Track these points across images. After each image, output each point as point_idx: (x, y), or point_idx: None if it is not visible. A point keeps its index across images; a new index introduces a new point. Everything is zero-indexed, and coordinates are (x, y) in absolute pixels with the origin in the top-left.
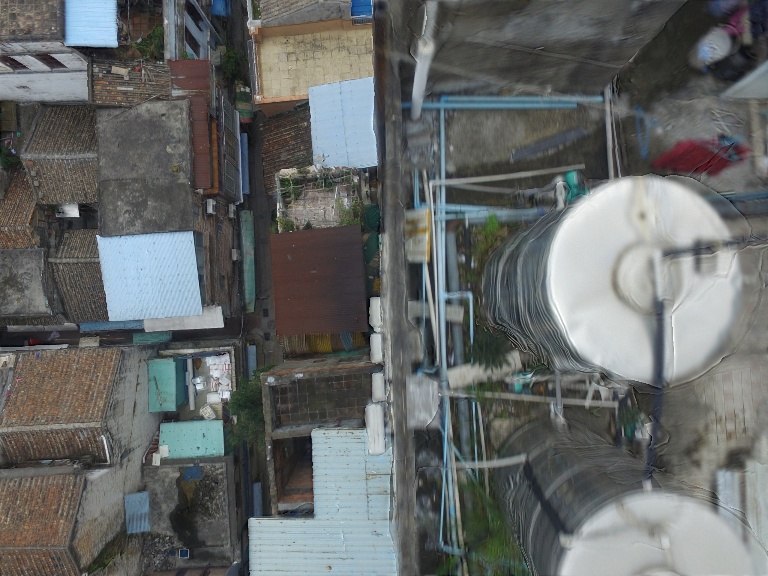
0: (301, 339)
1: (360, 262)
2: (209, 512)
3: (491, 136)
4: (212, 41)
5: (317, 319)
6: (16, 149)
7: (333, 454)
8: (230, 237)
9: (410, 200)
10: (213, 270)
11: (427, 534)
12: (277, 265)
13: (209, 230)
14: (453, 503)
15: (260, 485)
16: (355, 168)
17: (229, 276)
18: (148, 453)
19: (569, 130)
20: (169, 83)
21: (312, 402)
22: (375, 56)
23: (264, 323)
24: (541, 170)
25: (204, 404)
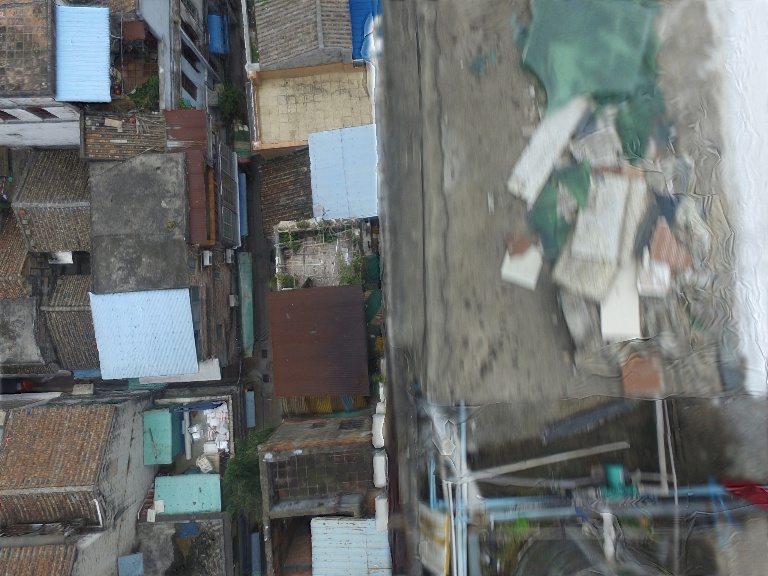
0: (300, 400)
1: (361, 324)
2: (205, 570)
3: (520, 411)
4: (210, 80)
5: (317, 381)
6: (8, 194)
7: (333, 546)
8: (228, 282)
9: (425, 497)
10: (210, 322)
11: None
12: (275, 324)
13: (206, 281)
14: None
15: (258, 535)
16: (356, 220)
17: (227, 323)
18: (143, 508)
19: (612, 404)
20: (164, 134)
21: (311, 476)
22: (386, 380)
23: (263, 364)
24: (579, 451)
25: (201, 453)
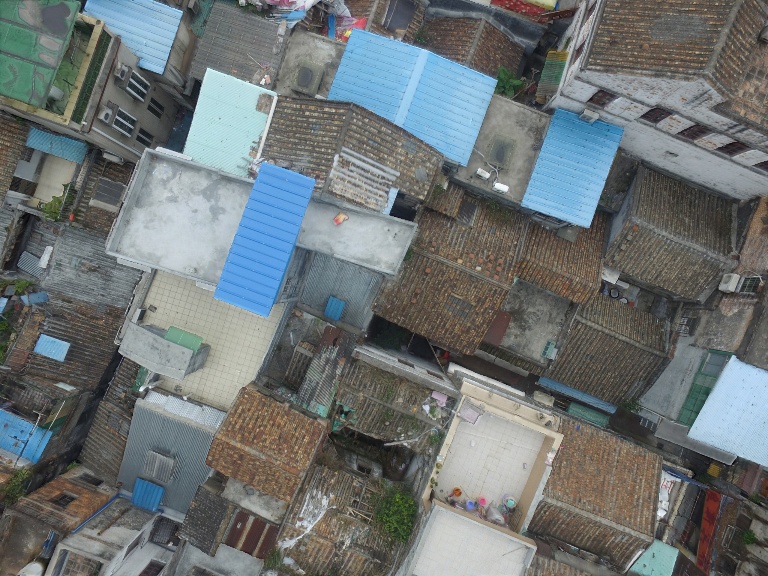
0: None
1: None
2: None
3: None
4: None
5: None
6: None
7: None
8: None
9: None
10: None
11: None
12: None
13: None
14: None
15: None
16: None
17: None
18: None
19: None
20: None
21: None
22: None
23: None
24: None
25: None
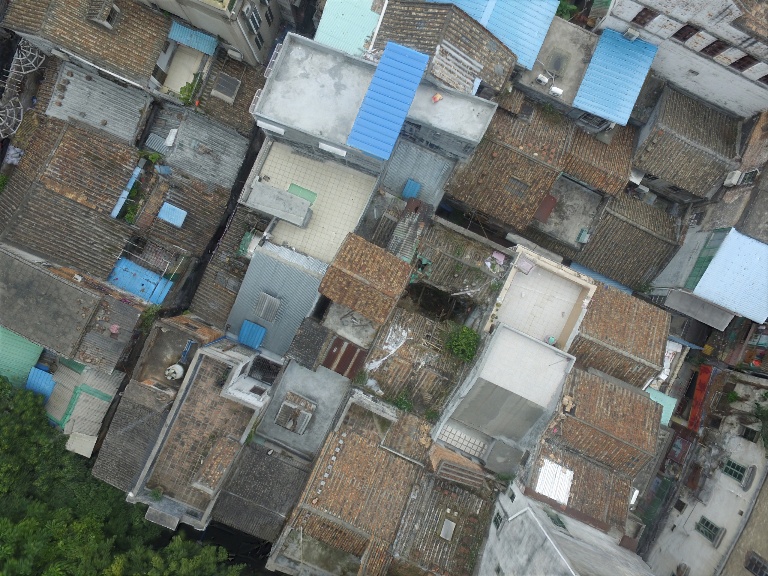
0: None
1: None
2: None
3: None
4: None
5: None
6: None
7: None
8: None
9: None
10: None
11: None
12: None
13: None
14: None
15: None
16: None
17: None
18: None
19: None
20: None
21: None
22: None
23: None
24: None
25: None
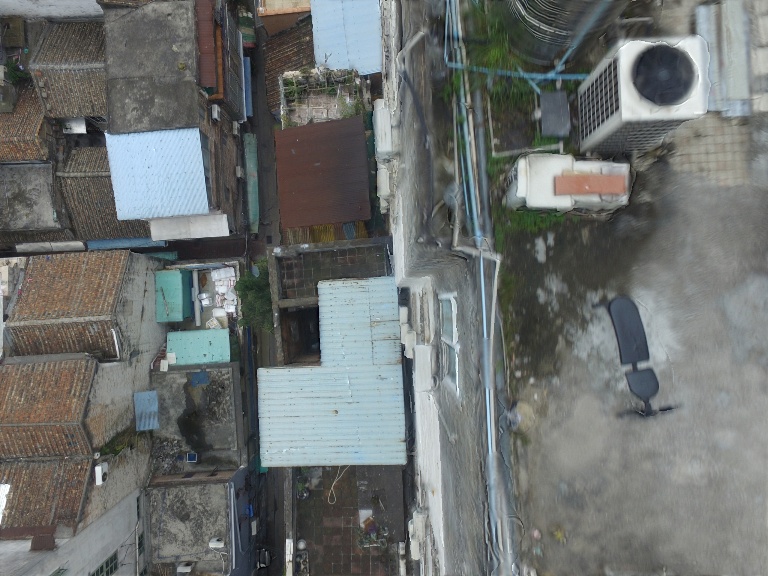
0: (305, 234)
1: (362, 152)
2: (216, 416)
3: None
4: None
5: (321, 210)
6: (24, 65)
7: (339, 304)
8: (234, 155)
9: None
10: (218, 177)
11: (433, 61)
12: (281, 160)
13: (214, 138)
14: (456, 28)
15: None
16: (357, 71)
17: (233, 192)
18: (156, 360)
19: None
20: None
21: (317, 277)
22: None
23: None
24: None
25: None
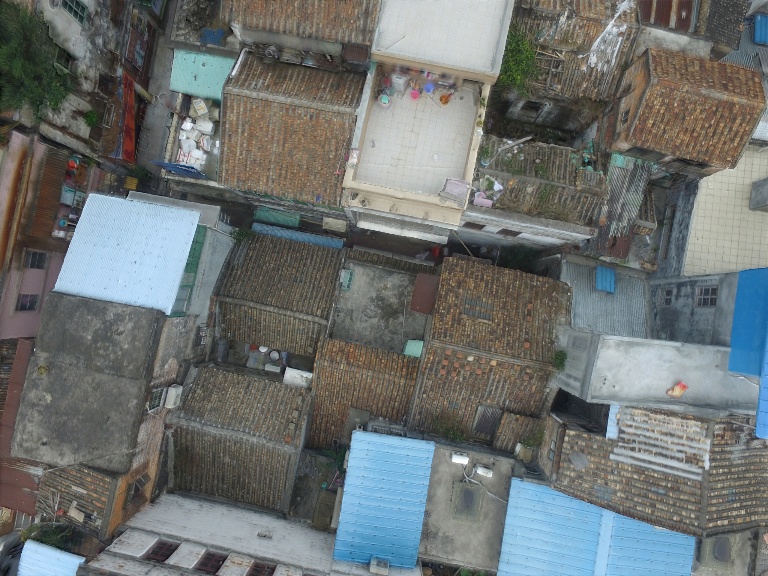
0: None
1: None
2: None
3: None
4: None
5: None
6: None
7: None
8: None
9: None
10: None
11: None
12: None
13: None
14: None
15: None
16: None
17: None
18: None
19: None
20: (41, 486)
21: None
22: None
23: None
24: None
25: None
